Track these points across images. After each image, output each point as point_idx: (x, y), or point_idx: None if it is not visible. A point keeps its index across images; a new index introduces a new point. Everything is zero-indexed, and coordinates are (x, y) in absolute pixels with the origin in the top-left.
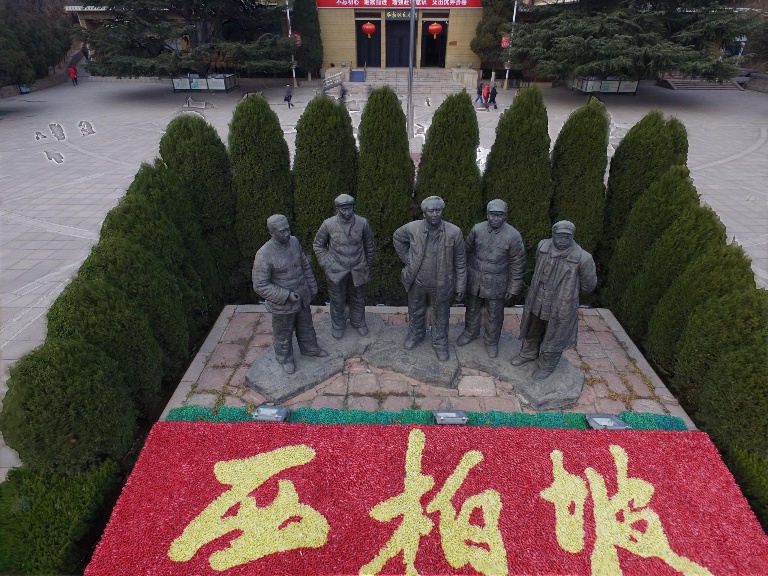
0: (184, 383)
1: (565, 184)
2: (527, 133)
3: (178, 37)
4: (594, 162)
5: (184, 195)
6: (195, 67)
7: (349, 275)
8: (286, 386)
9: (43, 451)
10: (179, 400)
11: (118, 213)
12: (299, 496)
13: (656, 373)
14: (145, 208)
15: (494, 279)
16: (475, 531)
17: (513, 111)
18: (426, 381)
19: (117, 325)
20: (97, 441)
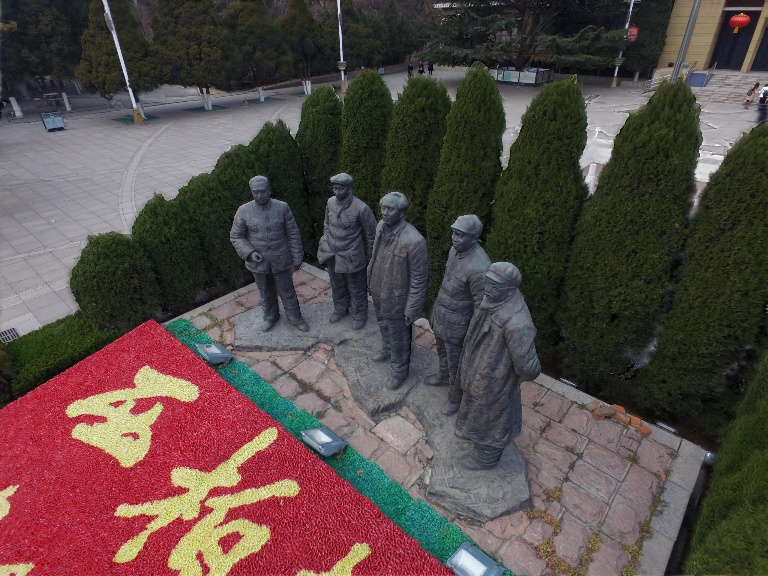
0: (209, 304)
1: (700, 237)
2: (643, 147)
3: (499, 29)
4: (760, 213)
5: (292, 155)
6: (502, 58)
7: (334, 259)
8: (250, 339)
9: (81, 303)
10: (192, 314)
11: (223, 156)
12: (154, 422)
13: (664, 574)
14: (242, 157)
15: (447, 315)
16: (215, 551)
17: (637, 113)
18: (355, 398)
19: (163, 237)
20: (108, 312)
